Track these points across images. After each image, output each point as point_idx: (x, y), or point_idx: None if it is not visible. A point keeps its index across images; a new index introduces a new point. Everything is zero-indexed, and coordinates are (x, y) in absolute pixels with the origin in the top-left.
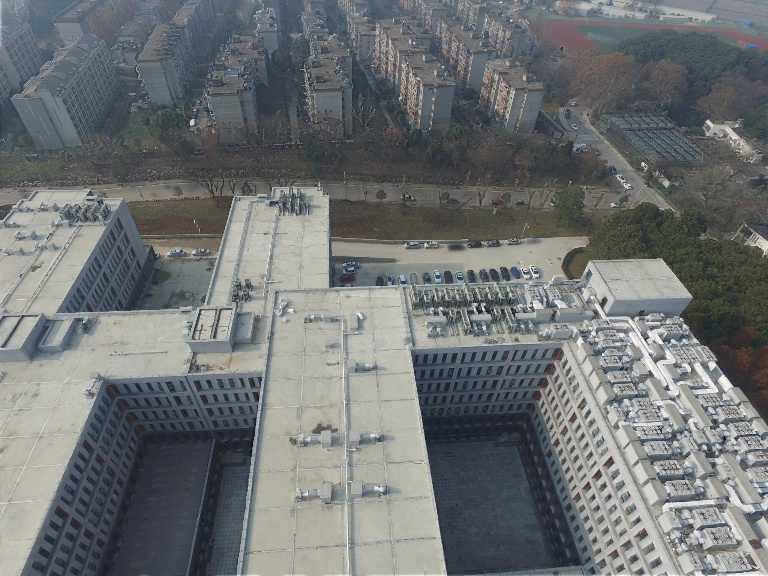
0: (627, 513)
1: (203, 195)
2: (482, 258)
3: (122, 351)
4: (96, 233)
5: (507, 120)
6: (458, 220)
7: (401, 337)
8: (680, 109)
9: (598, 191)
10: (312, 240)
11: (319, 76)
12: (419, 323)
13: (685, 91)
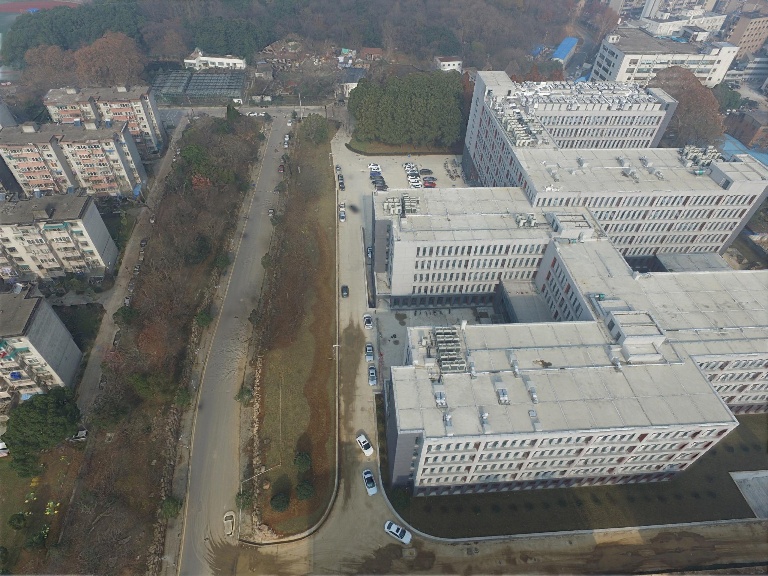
0: (600, 124)
1: (238, 378)
2: (357, 186)
3: (606, 273)
4: (477, 332)
5: (150, 133)
6: (310, 189)
7: (553, 152)
8: (154, 65)
9: (268, 126)
10: (453, 196)
11: (46, 207)
12: (539, 146)
13: (141, 50)
